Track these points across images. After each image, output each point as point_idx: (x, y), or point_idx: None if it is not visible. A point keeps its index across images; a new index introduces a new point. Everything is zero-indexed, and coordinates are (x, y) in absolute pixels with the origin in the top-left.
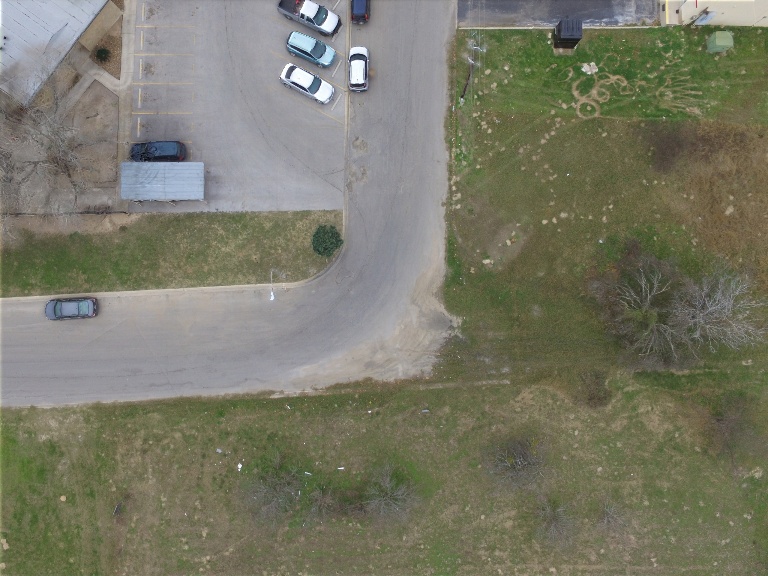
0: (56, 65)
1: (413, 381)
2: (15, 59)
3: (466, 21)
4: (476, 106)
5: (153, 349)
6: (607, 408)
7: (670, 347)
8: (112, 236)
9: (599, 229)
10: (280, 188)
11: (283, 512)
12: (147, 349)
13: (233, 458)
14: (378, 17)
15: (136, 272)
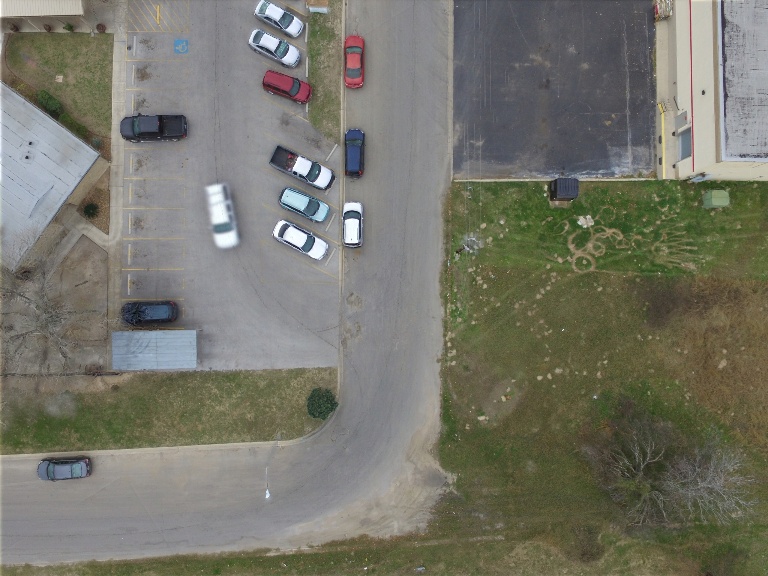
0: (42, 229)
1: (409, 538)
2: None
3: (461, 173)
4: (471, 261)
5: (148, 507)
6: (600, 562)
7: (662, 514)
8: (104, 395)
9: (594, 385)
10: (274, 346)
11: None
12: (142, 507)
13: None
14: (372, 169)
15: (129, 431)
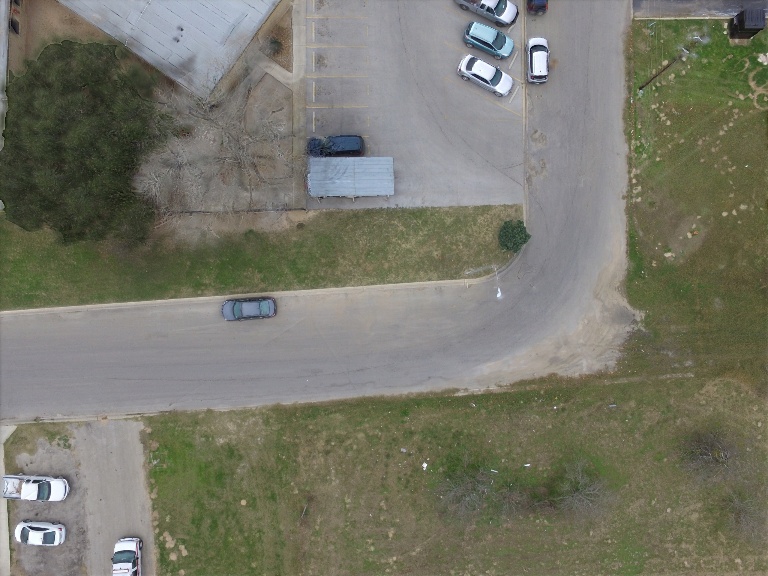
0: (237, 58)
1: (598, 376)
2: (193, 52)
3: (642, 11)
4: (655, 98)
5: (333, 349)
6: None
7: None
8: (289, 234)
9: None
10: (460, 183)
11: (471, 510)
12: (327, 349)
13: (418, 457)
14: (553, 7)
15: (314, 270)
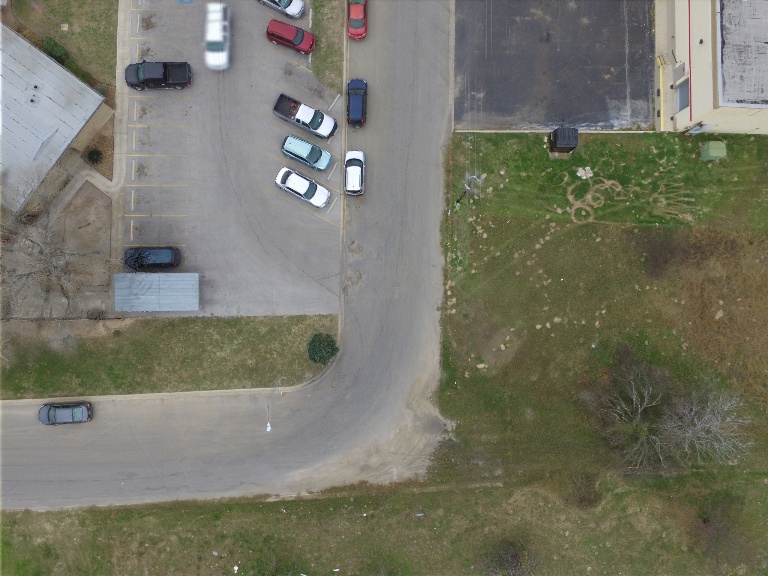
0: (47, 172)
1: (408, 485)
2: (4, 165)
3: (462, 124)
4: (472, 210)
5: (148, 453)
6: (597, 510)
7: (659, 459)
8: (106, 340)
9: (592, 334)
10: (275, 292)
11: None
12: (142, 453)
13: (229, 560)
14: (374, 119)
15: (130, 376)
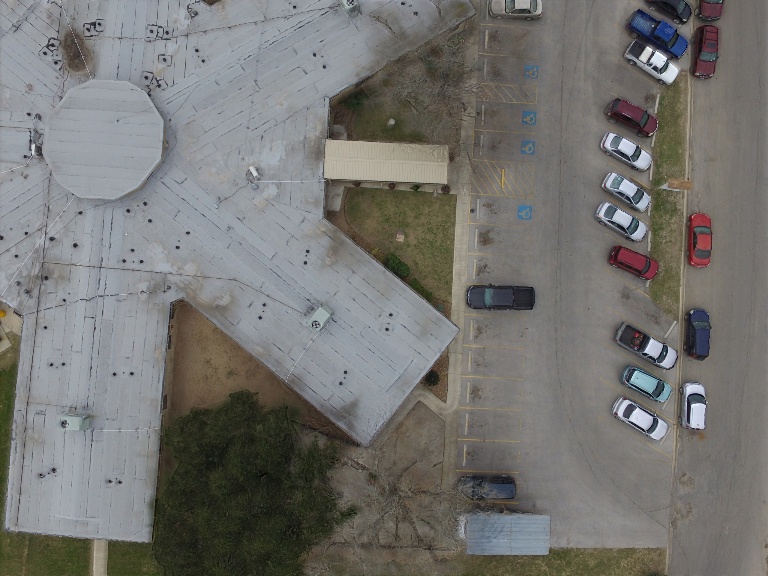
0: (399, 404)
1: None
2: (355, 394)
3: None
4: None
5: None
6: None
7: None
8: (432, 567)
9: None
10: (606, 524)
11: None
12: None
13: None
14: (710, 348)
15: None
